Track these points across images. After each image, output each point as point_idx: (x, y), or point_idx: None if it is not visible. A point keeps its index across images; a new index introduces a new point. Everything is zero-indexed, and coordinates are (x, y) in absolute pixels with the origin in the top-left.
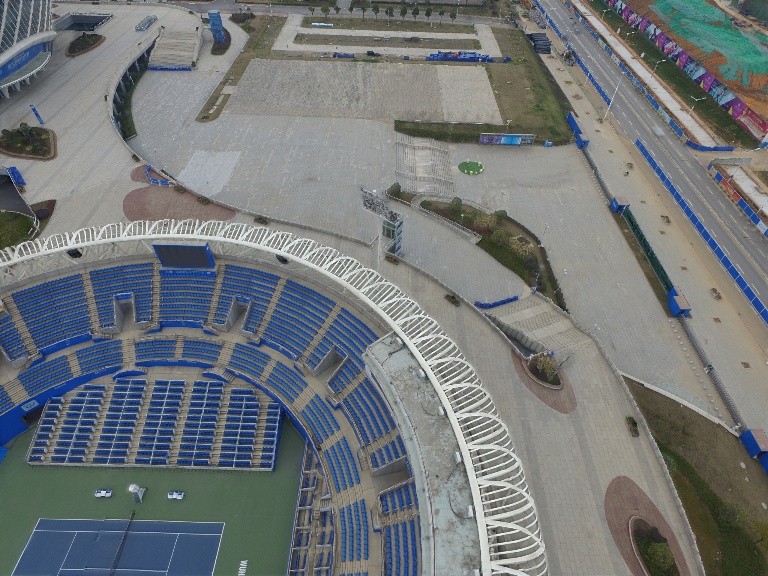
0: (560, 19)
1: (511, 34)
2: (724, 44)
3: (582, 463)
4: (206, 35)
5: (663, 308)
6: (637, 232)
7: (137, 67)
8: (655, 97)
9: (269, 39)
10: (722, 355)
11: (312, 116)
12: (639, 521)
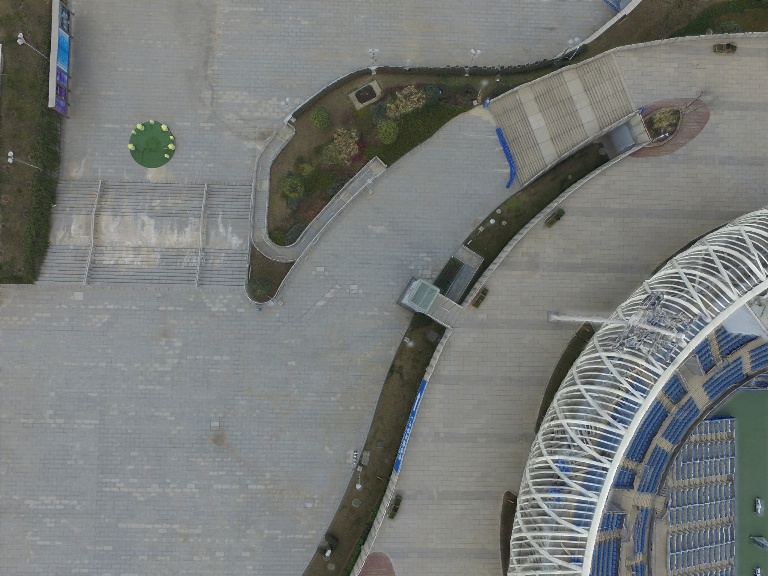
0: None
1: None
2: None
3: (762, 114)
4: None
5: None
6: None
7: None
8: None
9: None
10: None
11: None
12: None
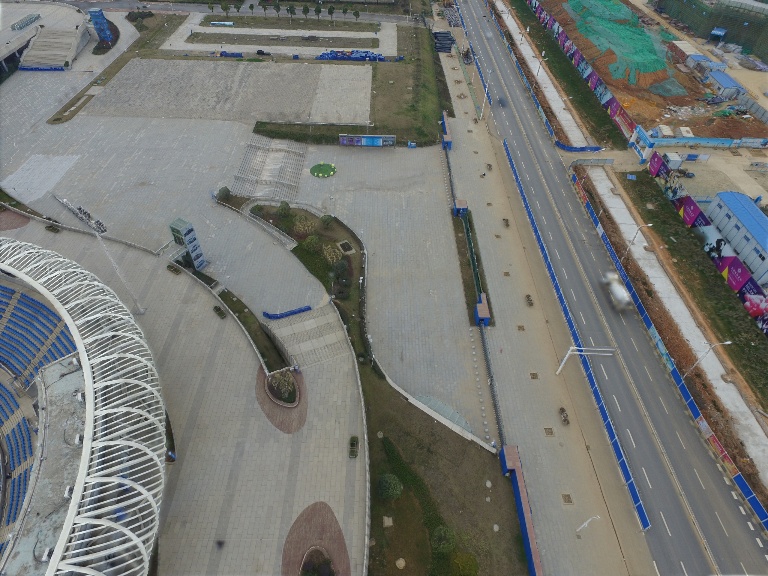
0: (474, 17)
1: (414, 32)
2: (620, 42)
3: (283, 488)
4: (95, 34)
5: (468, 316)
6: (468, 236)
7: (5, 67)
8: (541, 96)
9: (161, 38)
10: (513, 365)
11: (171, 117)
12: (315, 552)
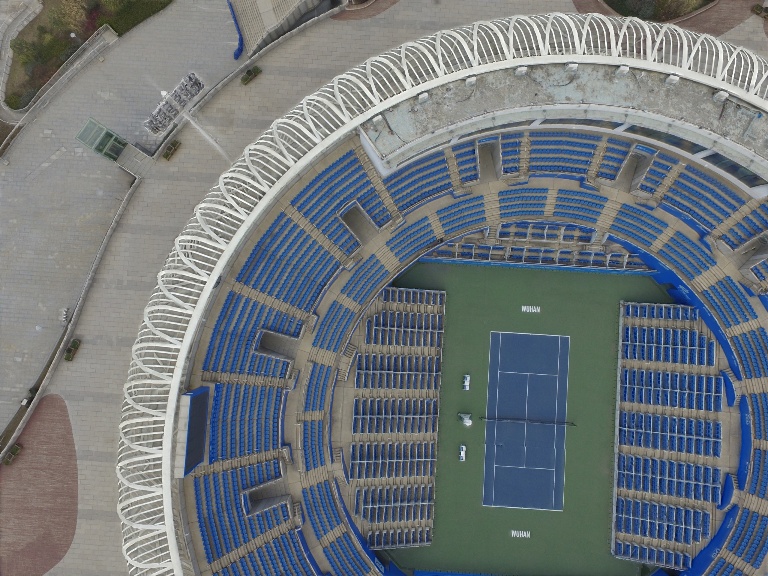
0: None
1: None
2: None
3: None
4: None
5: None
6: None
7: None
8: None
9: None
10: None
11: None
12: None
